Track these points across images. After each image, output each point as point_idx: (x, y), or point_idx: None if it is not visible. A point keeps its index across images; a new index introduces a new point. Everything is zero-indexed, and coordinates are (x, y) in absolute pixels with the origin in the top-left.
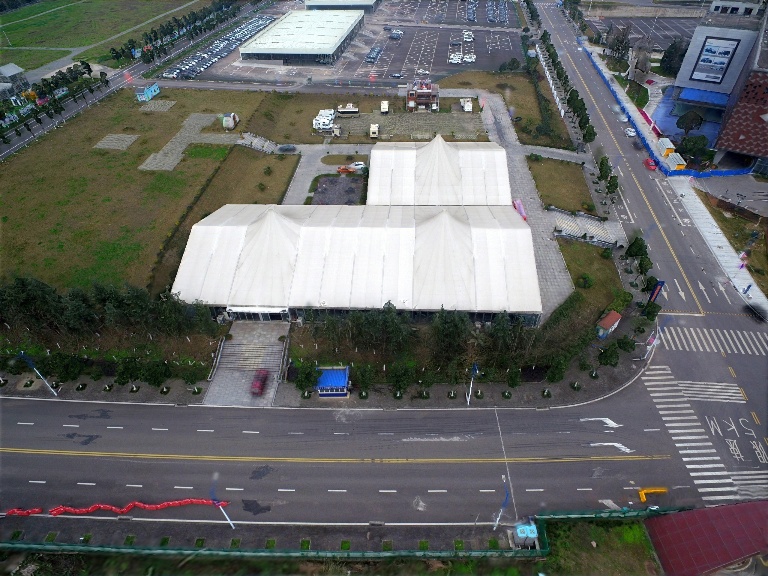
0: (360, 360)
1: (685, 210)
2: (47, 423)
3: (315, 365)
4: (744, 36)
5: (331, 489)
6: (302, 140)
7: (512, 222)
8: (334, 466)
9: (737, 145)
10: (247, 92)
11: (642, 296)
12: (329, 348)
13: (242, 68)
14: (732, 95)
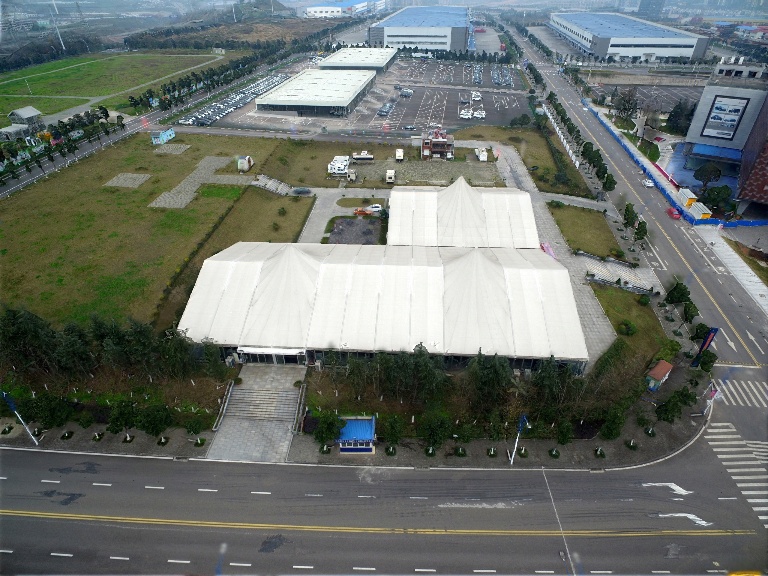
0: (385, 410)
1: (718, 258)
2: (23, 478)
3: (335, 415)
4: (753, 95)
5: (357, 566)
6: (317, 184)
7: (545, 263)
8: (359, 537)
9: (762, 195)
10: (262, 139)
11: (688, 345)
12: (351, 396)
13: (257, 118)
14: (747, 149)
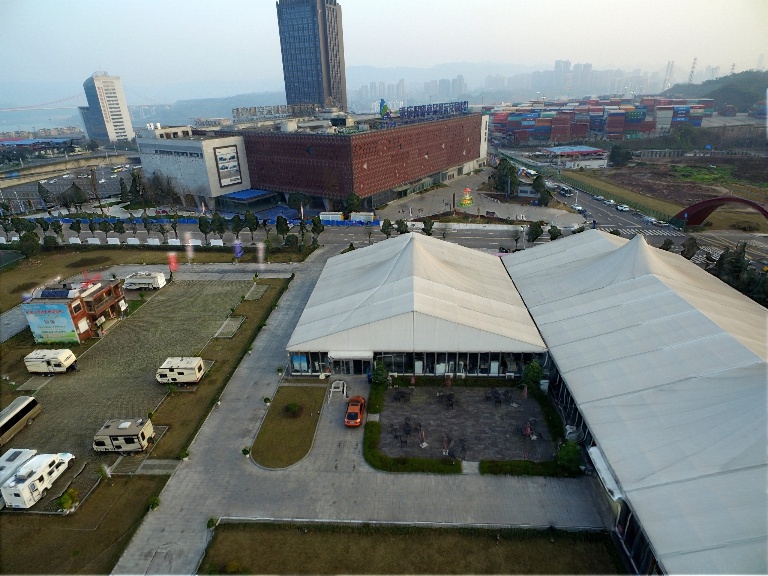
0: None
1: (434, 228)
2: None
3: None
4: (236, 141)
5: None
6: (93, 540)
7: (574, 241)
8: None
9: (362, 193)
10: None
11: None
12: None
13: None
14: (283, 178)
